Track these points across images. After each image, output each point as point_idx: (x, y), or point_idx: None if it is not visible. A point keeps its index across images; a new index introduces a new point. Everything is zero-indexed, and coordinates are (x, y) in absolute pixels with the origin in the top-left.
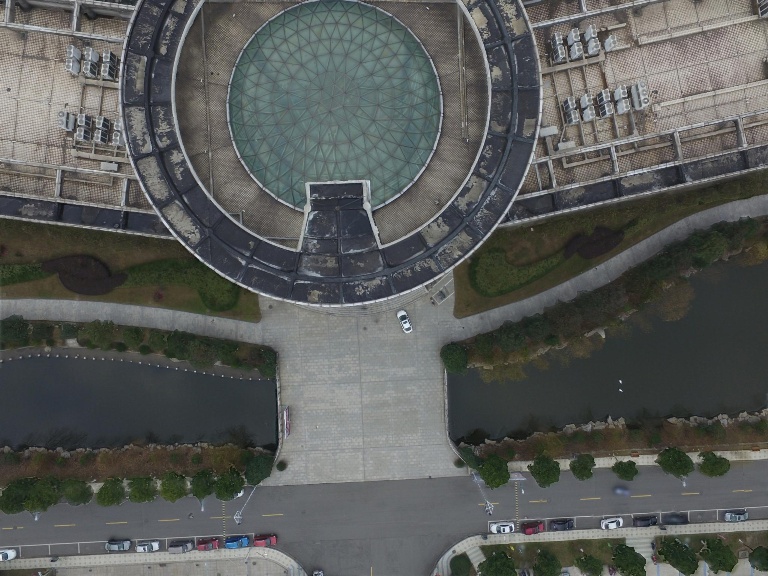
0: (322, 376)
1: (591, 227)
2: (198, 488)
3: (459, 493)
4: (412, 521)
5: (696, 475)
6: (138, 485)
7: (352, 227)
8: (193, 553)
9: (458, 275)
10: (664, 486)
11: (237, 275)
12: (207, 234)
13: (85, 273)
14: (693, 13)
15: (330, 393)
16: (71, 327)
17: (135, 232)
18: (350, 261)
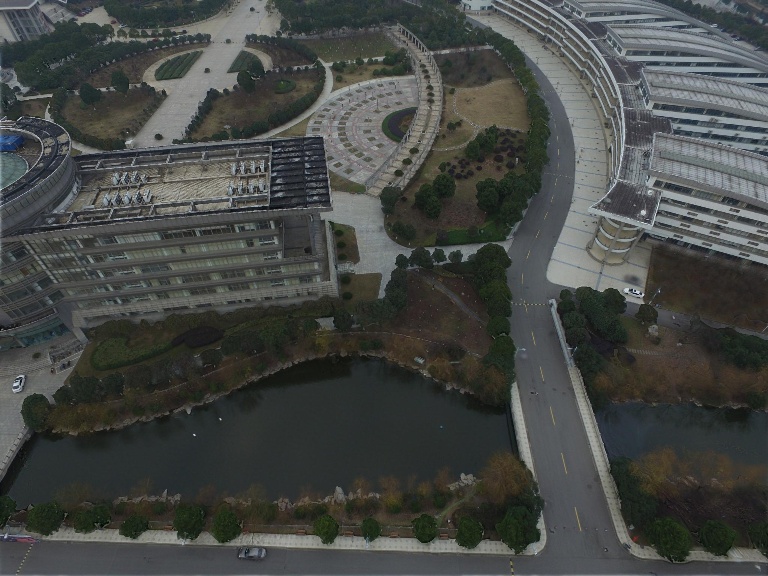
0: None
1: (193, 321)
2: None
3: None
4: None
5: (230, 562)
6: None
7: None
8: None
9: (85, 354)
10: (189, 574)
11: None
12: None
13: None
14: (200, 174)
15: None
16: None
17: None
18: None
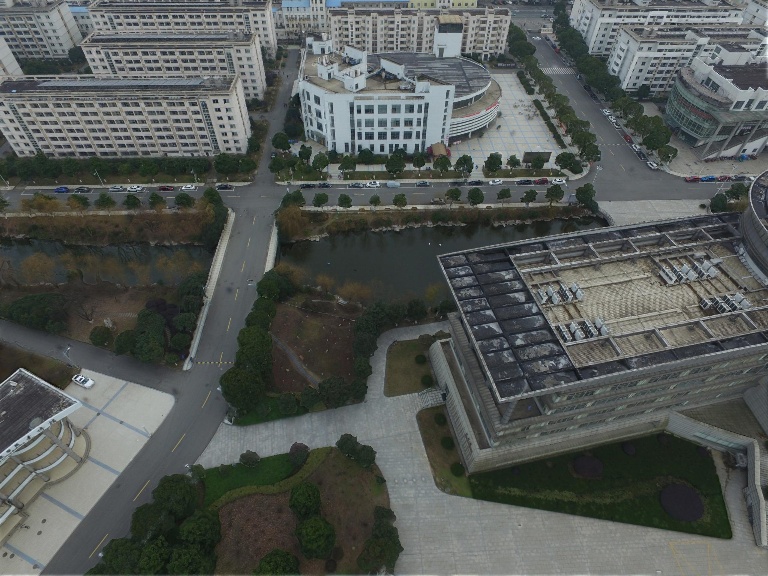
0: None
1: None
2: None
3: None
4: (612, 186)
5: None
6: None
7: None
8: None
9: None
10: None
11: None
12: None
13: None
14: None
15: None
16: None
17: None
18: None
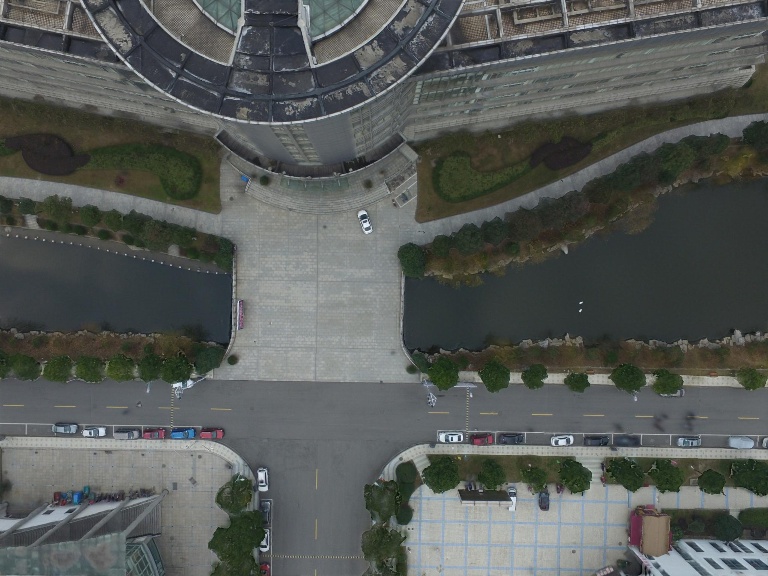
0: (279, 272)
1: (558, 134)
2: (144, 368)
3: (410, 400)
4: (361, 425)
5: (651, 398)
6: (85, 362)
7: (286, 45)
8: (139, 442)
9: (422, 178)
10: (618, 407)
11: (167, 87)
12: (138, 41)
13: (48, 151)
14: None
15: (286, 290)
16: (29, 201)
17: (75, 55)
18: (282, 80)
